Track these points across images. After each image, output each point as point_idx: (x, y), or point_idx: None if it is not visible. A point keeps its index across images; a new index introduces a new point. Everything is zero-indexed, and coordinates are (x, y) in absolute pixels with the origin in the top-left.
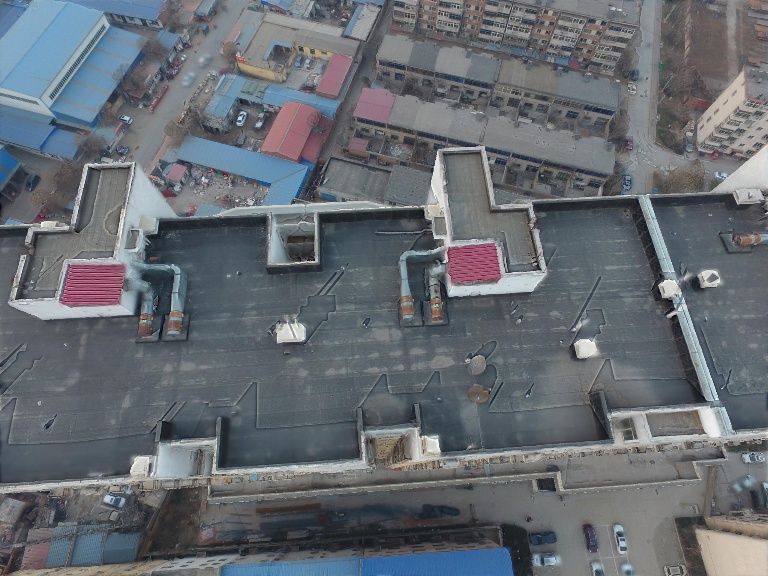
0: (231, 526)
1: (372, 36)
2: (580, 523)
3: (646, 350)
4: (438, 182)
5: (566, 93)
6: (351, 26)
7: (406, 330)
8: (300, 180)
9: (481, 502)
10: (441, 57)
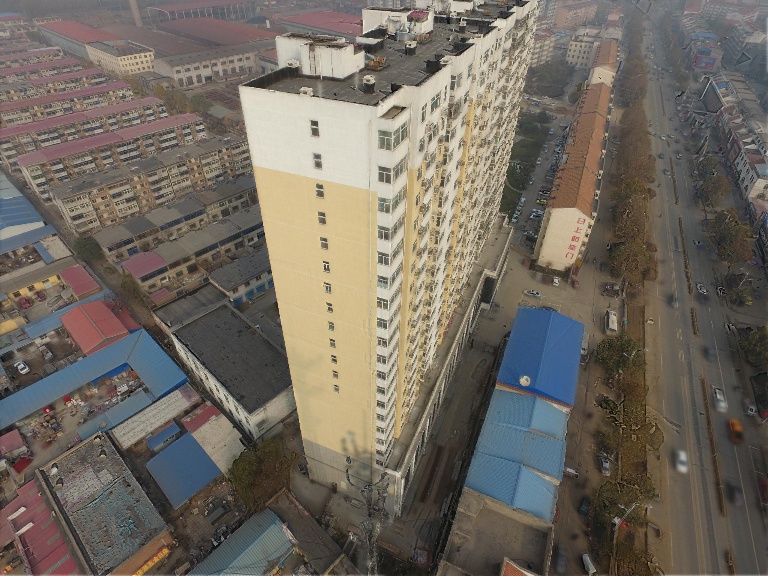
0: (425, 528)
1: (74, 250)
2: (516, 306)
3: (470, 28)
4: (374, 19)
5: (250, 186)
6: (47, 256)
7: (427, 44)
8: (149, 339)
9: (484, 346)
10: (152, 219)
